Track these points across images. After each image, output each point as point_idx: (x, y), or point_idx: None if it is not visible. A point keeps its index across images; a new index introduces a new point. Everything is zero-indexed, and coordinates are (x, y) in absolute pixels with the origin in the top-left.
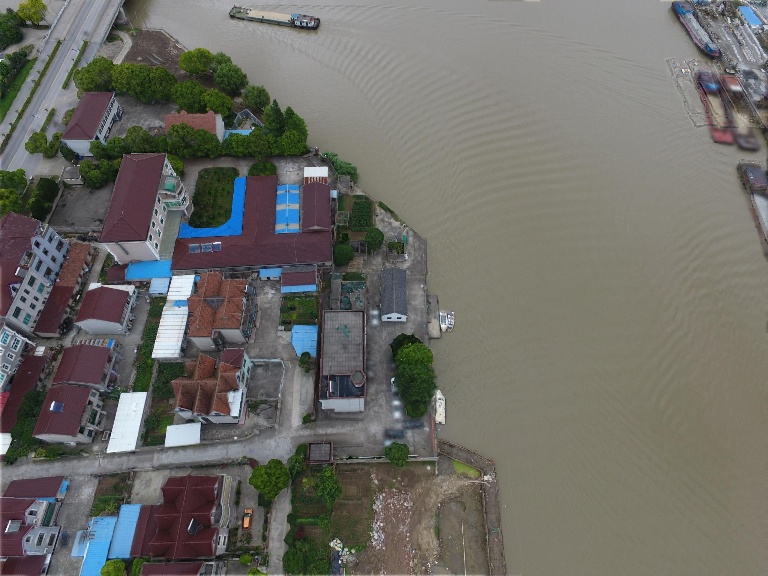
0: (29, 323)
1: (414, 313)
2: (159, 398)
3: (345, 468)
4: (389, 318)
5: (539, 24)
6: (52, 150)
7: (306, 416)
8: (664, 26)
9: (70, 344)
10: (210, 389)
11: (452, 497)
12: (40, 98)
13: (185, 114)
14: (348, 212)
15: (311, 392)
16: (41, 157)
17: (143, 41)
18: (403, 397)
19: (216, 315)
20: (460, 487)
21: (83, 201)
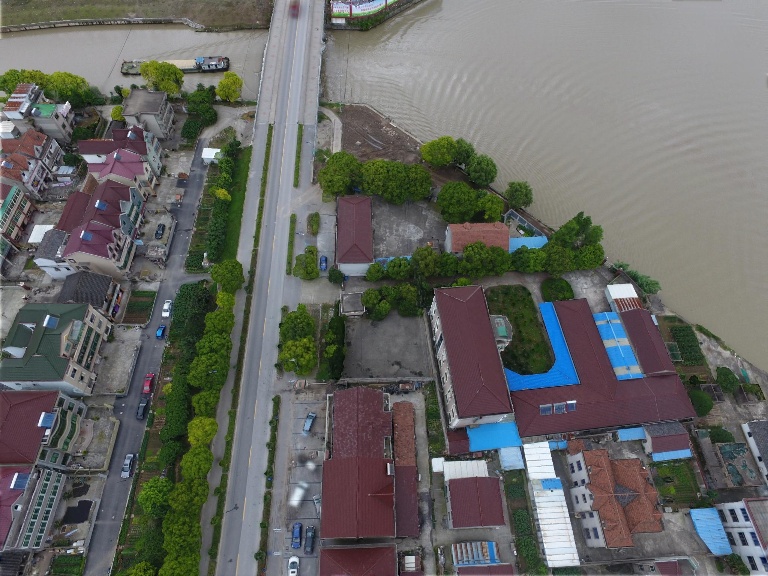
0: None
1: None
2: None
3: None
4: None
5: (765, 89)
6: None
7: None
8: None
9: (430, 544)
10: None
11: None
12: (272, 200)
13: (470, 227)
14: (676, 343)
15: None
16: (300, 279)
17: (352, 119)
18: None
19: (629, 514)
20: None
21: (369, 337)
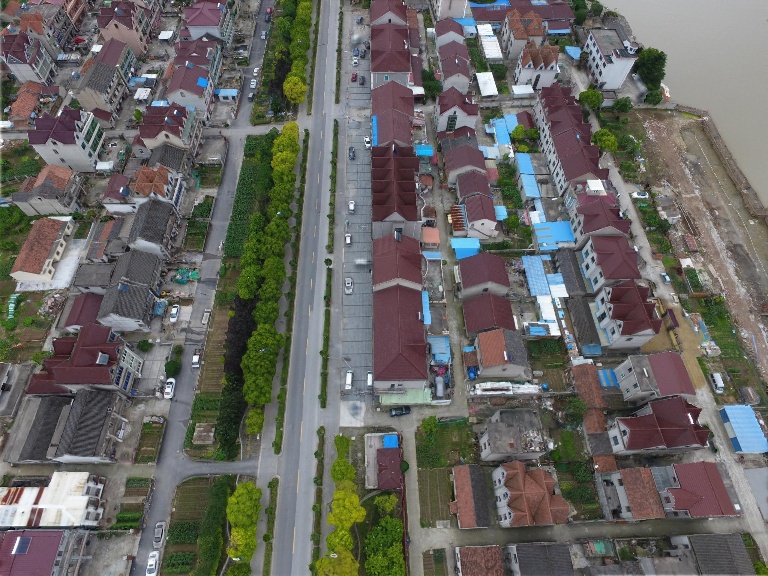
0: None
1: None
2: (495, 80)
3: None
4: None
5: None
6: None
7: (591, 84)
8: None
9: (426, 58)
10: (544, 56)
11: (686, 128)
12: None
13: None
14: None
15: (586, 78)
16: None
17: None
18: (645, 79)
19: (528, 29)
20: (690, 123)
21: None
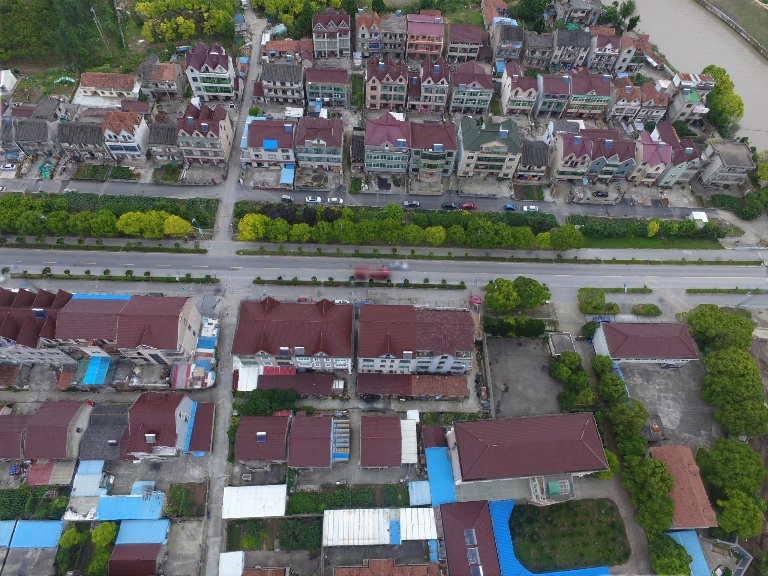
0: (366, 367)
1: None
2: None
3: None
4: None
5: None
6: (591, 309)
7: None
8: None
9: (351, 407)
10: None
11: None
12: (663, 272)
13: (694, 473)
14: None
15: None
16: None
17: None
18: None
19: None
20: None
21: (530, 363)
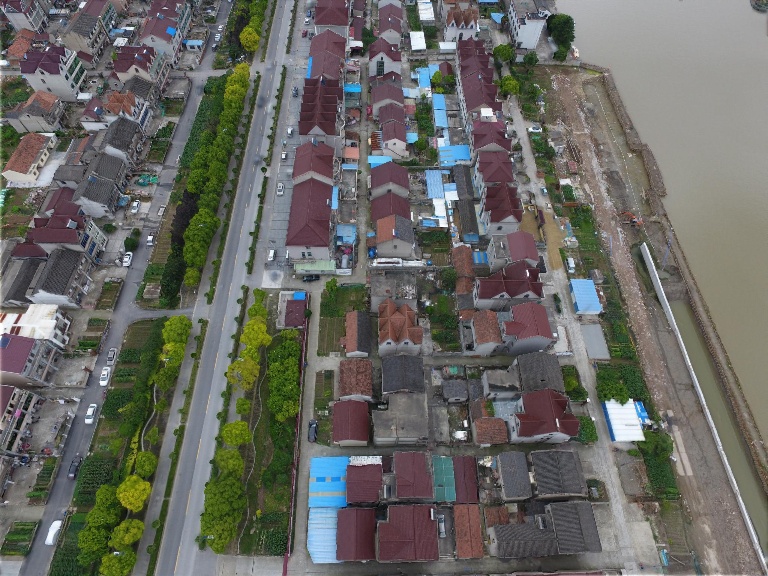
0: None
1: None
2: (427, 39)
3: (532, 66)
4: None
5: None
6: None
7: (509, 43)
8: None
9: (369, 20)
10: (466, 17)
11: (588, 82)
12: None
13: None
14: None
15: (507, 39)
16: None
17: None
18: (557, 41)
19: None
20: (592, 78)
21: None
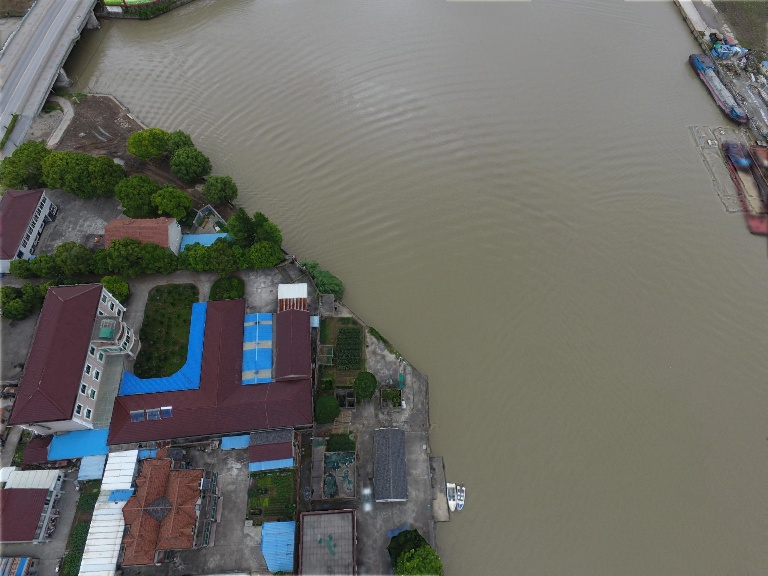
0: None
1: (415, 487)
2: None
3: None
4: (385, 500)
5: (546, 84)
6: None
7: None
8: (683, 84)
9: None
10: None
11: None
12: None
13: (131, 222)
14: (332, 346)
15: None
16: None
17: (87, 110)
18: None
19: (161, 529)
20: None
21: (1, 338)
